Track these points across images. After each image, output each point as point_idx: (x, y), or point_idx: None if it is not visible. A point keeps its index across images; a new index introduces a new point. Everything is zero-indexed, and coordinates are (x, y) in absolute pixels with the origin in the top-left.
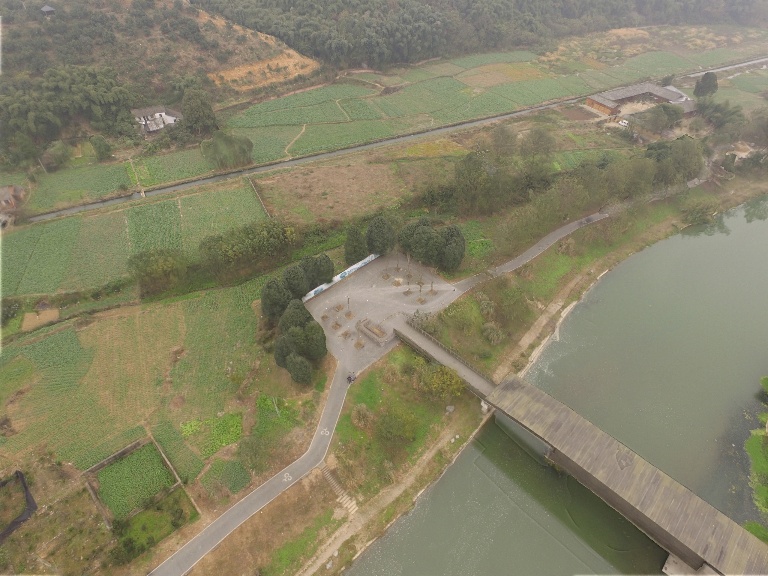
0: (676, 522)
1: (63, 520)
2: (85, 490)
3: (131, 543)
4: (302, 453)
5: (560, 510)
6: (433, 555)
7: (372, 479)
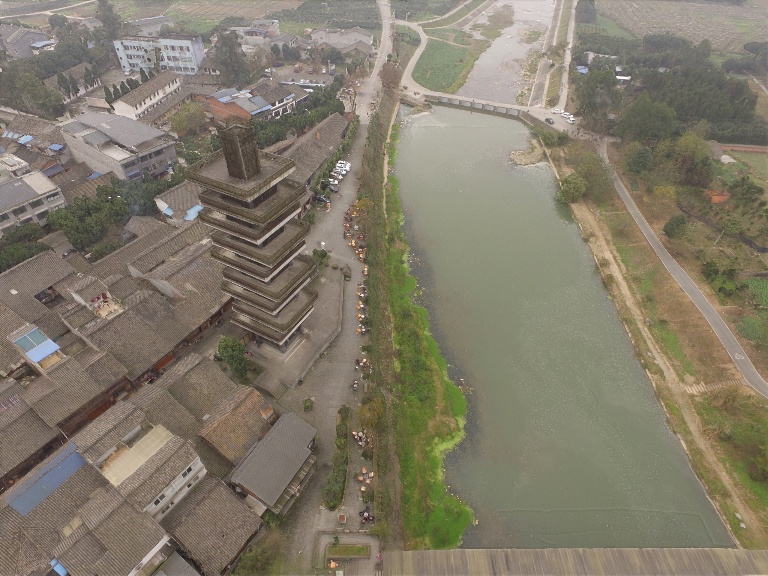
0: (545, 570)
1: (745, 258)
2: (767, 269)
3: (715, 272)
4: (763, 376)
5: (607, 543)
6: (623, 414)
7: (714, 416)
